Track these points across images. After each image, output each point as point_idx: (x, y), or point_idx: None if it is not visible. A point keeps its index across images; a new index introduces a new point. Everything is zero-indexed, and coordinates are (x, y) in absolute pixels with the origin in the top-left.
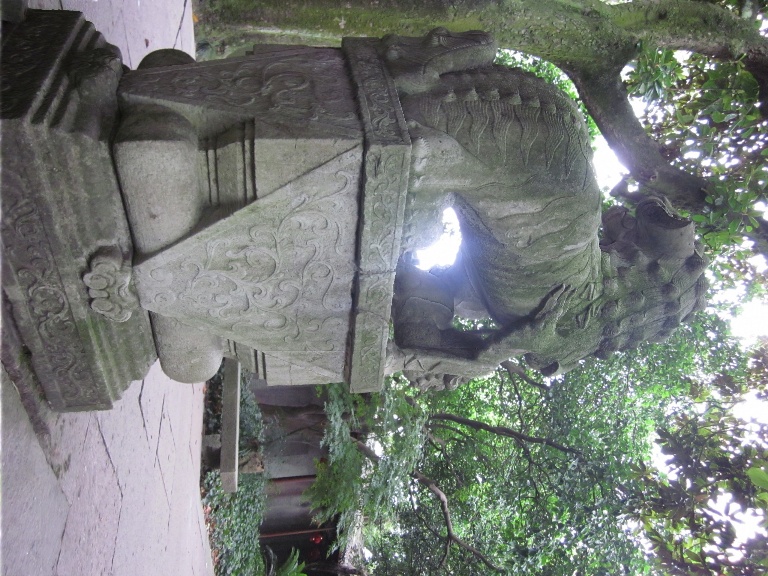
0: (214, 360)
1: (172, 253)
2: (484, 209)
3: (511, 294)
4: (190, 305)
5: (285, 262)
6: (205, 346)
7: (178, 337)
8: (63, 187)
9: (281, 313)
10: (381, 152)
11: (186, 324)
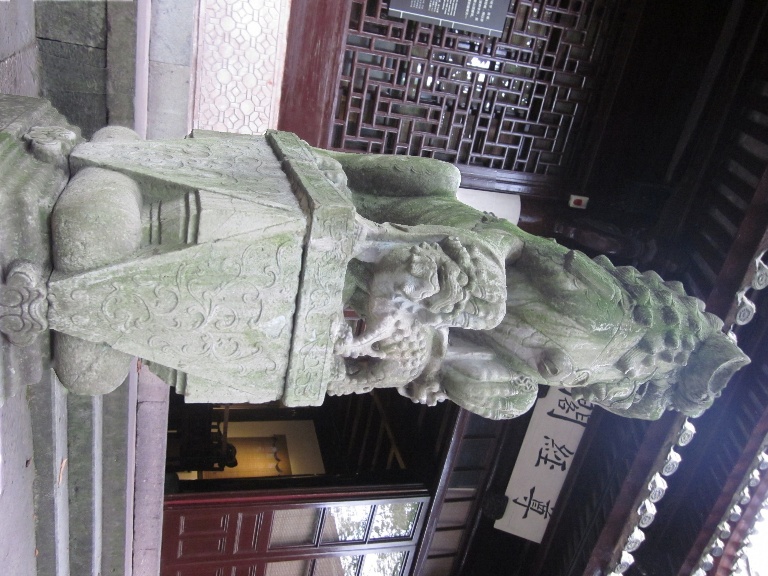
0: (132, 203)
1: (119, 142)
2: (365, 160)
3: (451, 225)
4: (122, 160)
5: (218, 155)
6: (126, 186)
7: (97, 175)
8: (51, 119)
9: (216, 171)
10: (276, 131)
11: (112, 167)
